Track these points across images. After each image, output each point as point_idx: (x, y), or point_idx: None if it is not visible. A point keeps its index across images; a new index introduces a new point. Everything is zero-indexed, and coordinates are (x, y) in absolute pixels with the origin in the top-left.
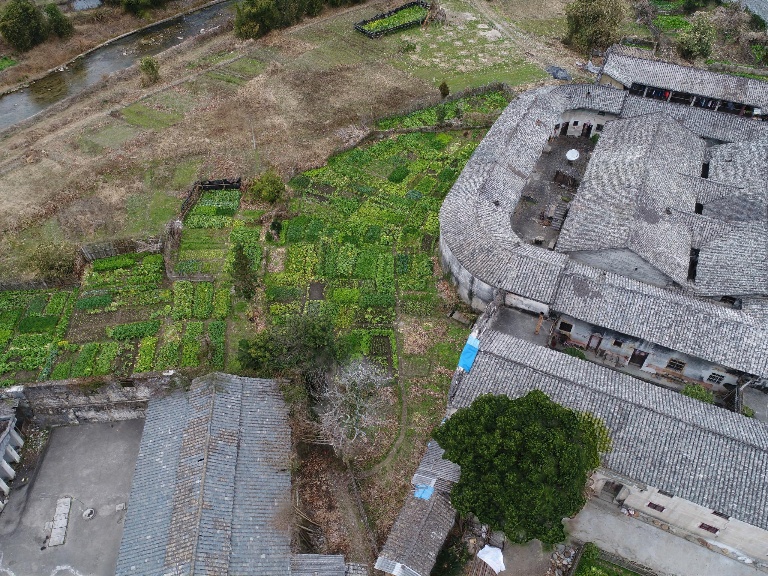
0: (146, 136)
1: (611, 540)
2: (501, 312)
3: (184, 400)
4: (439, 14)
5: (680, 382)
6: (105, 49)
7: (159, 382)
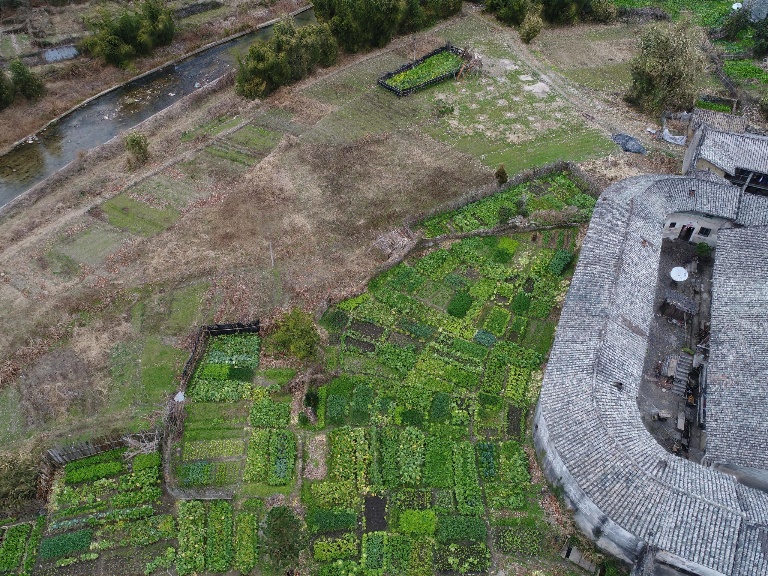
0: (134, 247)
1: None
2: None
3: None
4: (475, 64)
5: None
6: (83, 111)
7: None
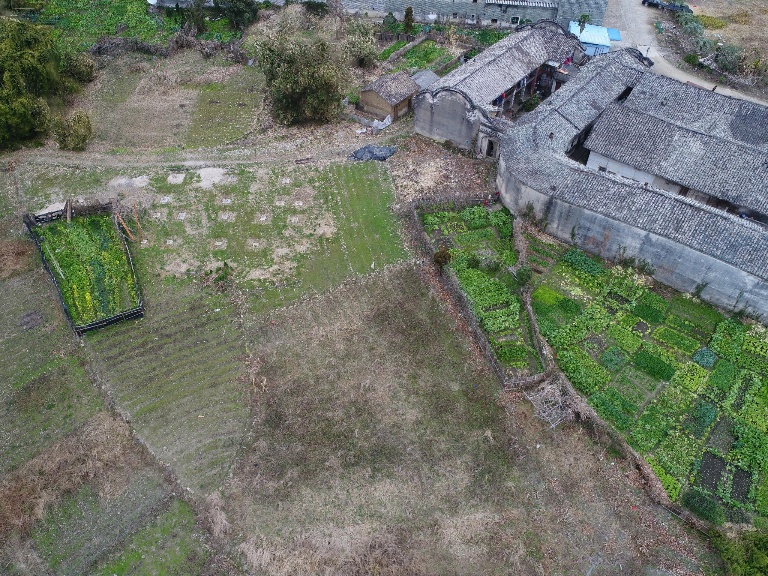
0: None
1: None
2: None
3: None
4: (119, 208)
5: None
6: None
7: None
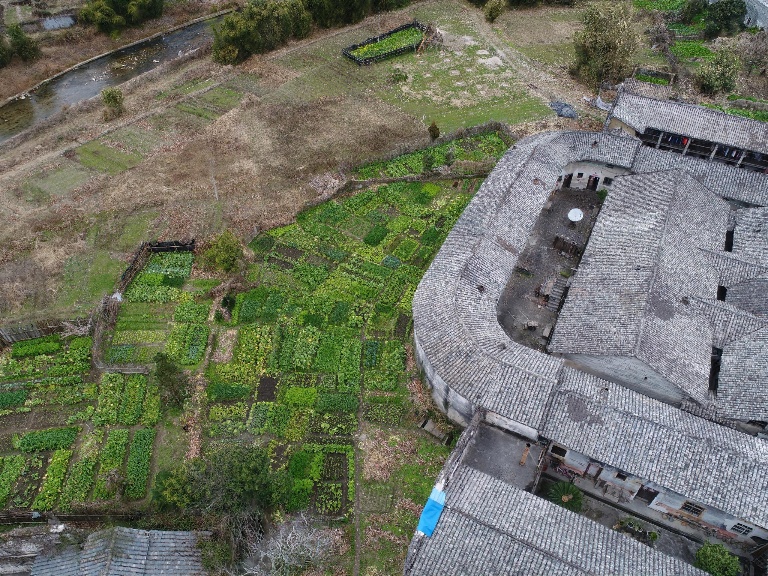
0: (98, 182)
1: None
2: (480, 432)
3: (75, 564)
4: (435, 38)
5: (697, 526)
6: (73, 73)
7: (46, 539)
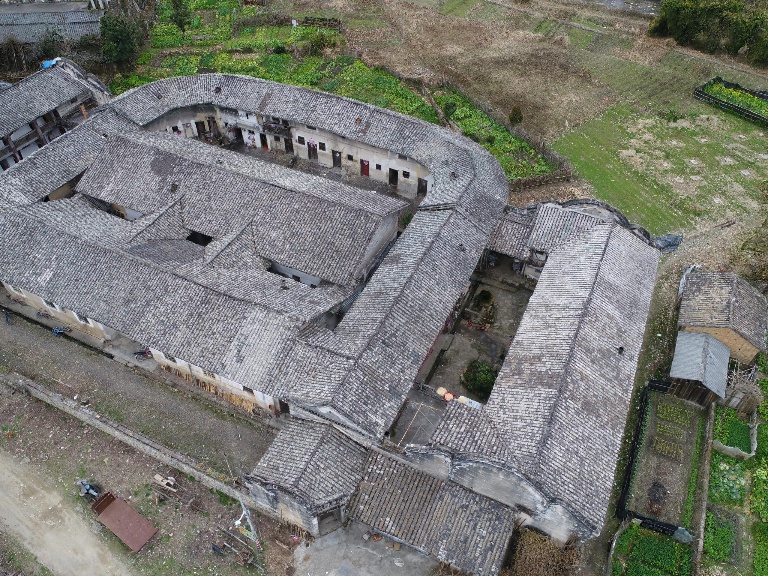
0: None
1: None
2: None
3: None
4: None
5: None
6: None
7: None
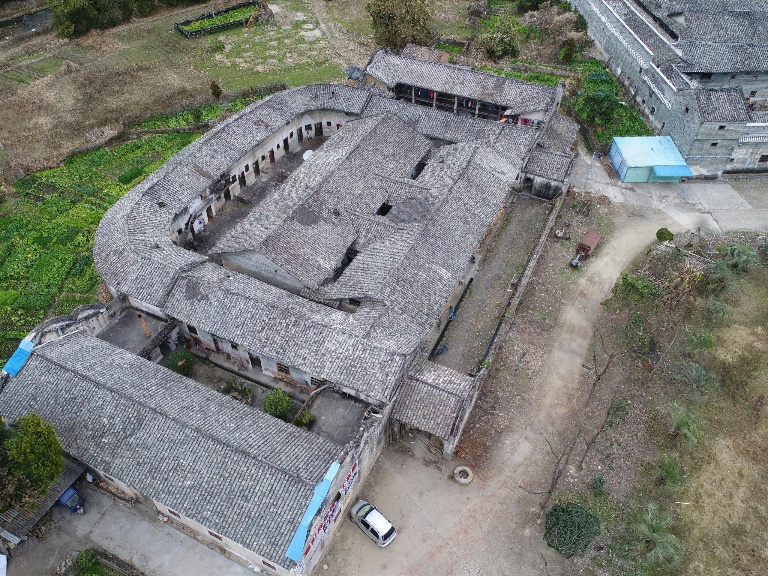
0: None
1: (132, 547)
2: (126, 315)
3: None
4: (265, 14)
5: (295, 386)
6: None
7: None
